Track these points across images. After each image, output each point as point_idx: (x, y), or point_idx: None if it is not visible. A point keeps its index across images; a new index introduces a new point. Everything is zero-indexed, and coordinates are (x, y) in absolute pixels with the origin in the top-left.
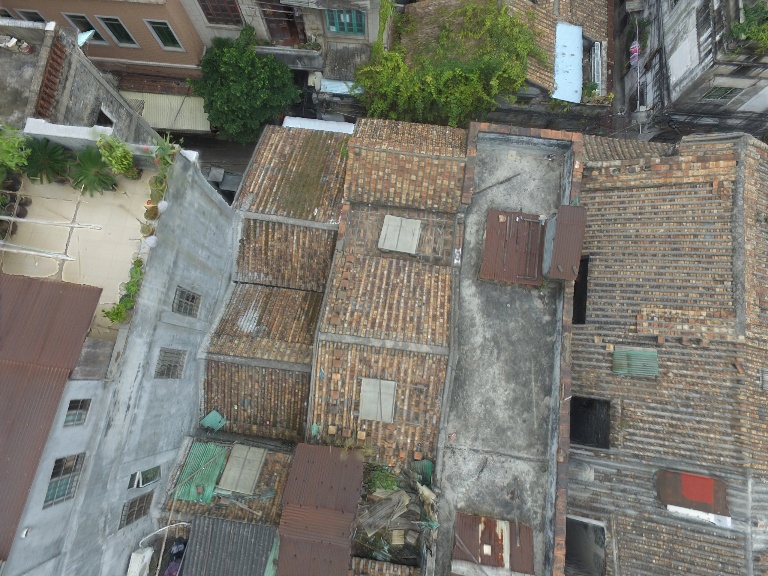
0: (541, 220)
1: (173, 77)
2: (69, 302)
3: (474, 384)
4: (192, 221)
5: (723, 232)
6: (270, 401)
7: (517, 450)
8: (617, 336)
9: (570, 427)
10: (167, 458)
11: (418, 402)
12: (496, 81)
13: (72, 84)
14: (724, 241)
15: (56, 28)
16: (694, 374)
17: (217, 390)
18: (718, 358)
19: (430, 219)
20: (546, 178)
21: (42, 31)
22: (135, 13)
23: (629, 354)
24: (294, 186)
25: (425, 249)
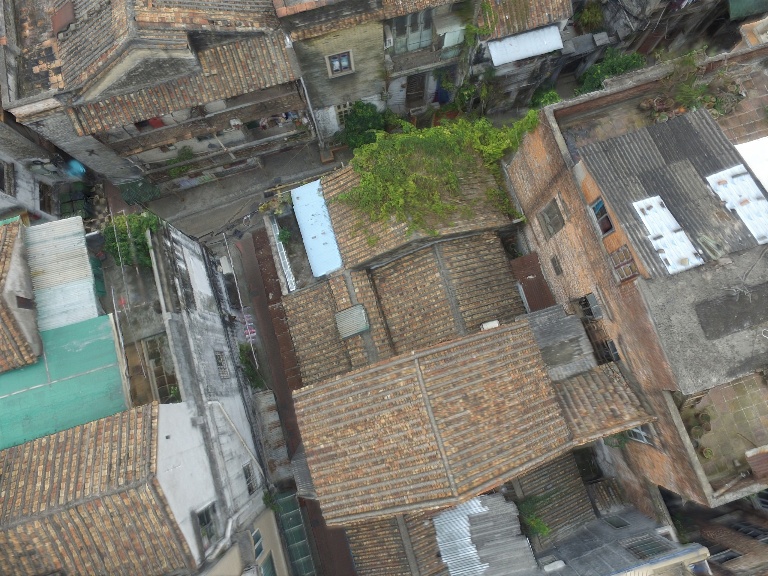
0: None
1: None
2: None
3: None
4: None
5: None
6: None
7: None
8: None
9: None
10: None
11: None
12: None
13: None
14: None
15: None
16: None
17: None
18: None
19: None
20: (298, 2)
21: None
22: None
23: None
24: None
25: None
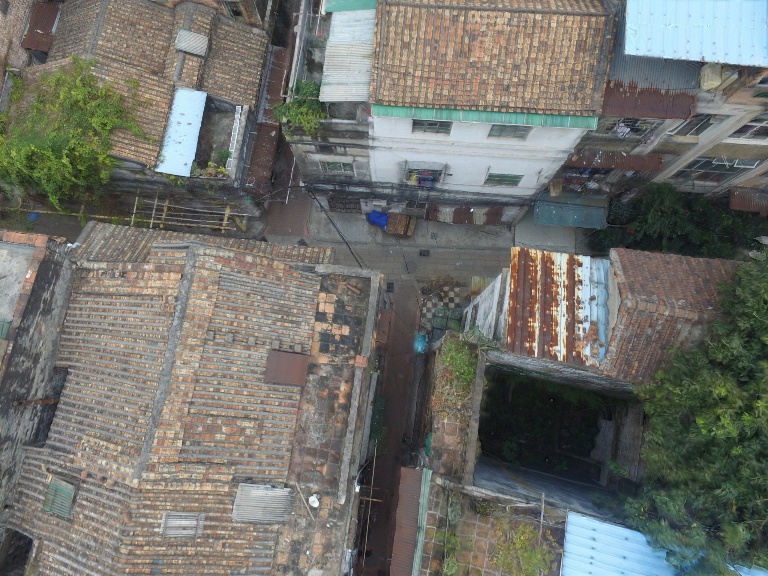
0: None
1: None
2: None
3: None
4: None
5: (159, 354)
6: None
7: None
8: (59, 465)
9: None
10: None
11: None
12: (66, 159)
13: None
14: (157, 365)
15: None
16: (98, 518)
17: None
18: (117, 502)
19: None
20: None
21: None
22: None
23: (57, 489)
24: None
25: None
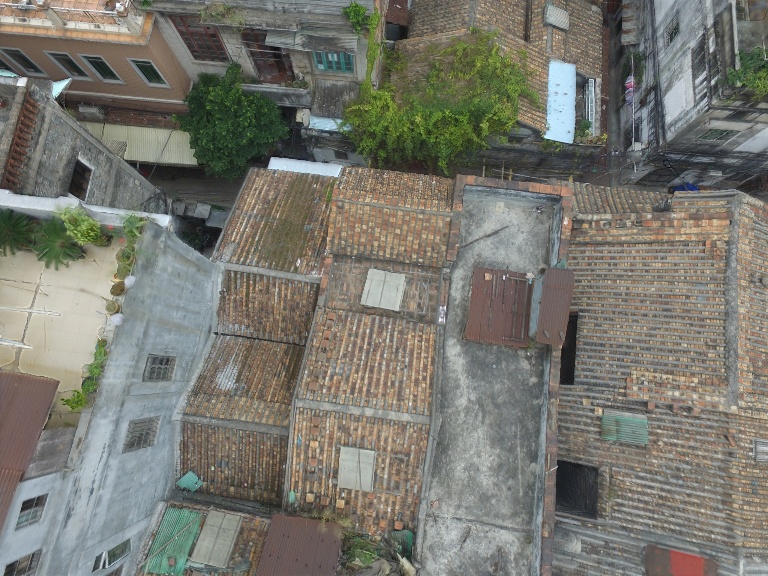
0: (528, 279)
1: (159, 112)
2: (24, 396)
3: (458, 449)
4: (165, 286)
5: (716, 294)
6: (248, 463)
7: (501, 519)
8: (606, 399)
9: (558, 486)
10: (138, 529)
11: (399, 471)
12: (486, 124)
13: (46, 138)
14: (717, 304)
15: (28, 83)
16: (685, 444)
17: (193, 451)
18: (710, 428)
19: (415, 273)
20: (535, 231)
21: (14, 87)
22: (118, 52)
23: (618, 420)
24: (277, 235)
25: (409, 304)
